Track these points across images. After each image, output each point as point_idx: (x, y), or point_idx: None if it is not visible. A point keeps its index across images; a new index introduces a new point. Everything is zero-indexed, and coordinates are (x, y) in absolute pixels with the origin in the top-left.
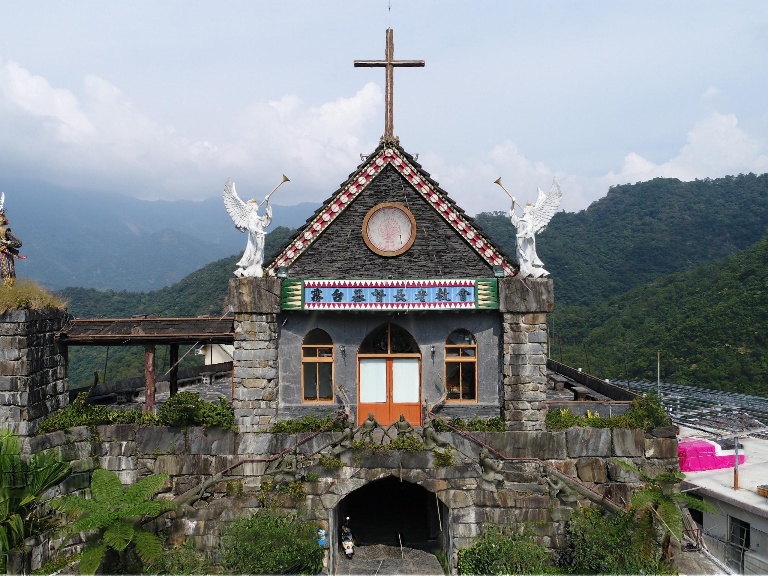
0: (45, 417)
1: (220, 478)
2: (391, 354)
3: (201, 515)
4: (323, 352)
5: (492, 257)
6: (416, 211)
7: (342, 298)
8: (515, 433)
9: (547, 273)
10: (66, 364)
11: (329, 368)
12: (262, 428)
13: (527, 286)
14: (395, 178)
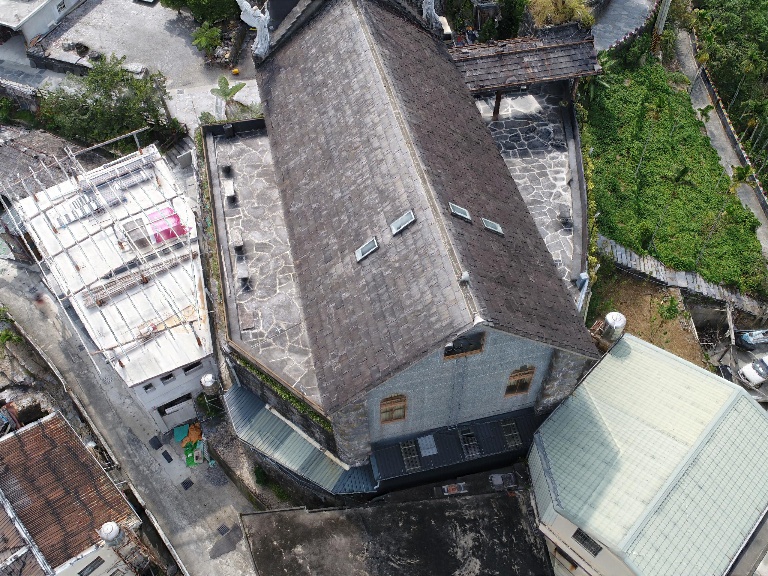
0: None
1: None
2: None
3: None
4: None
5: None
6: None
7: None
8: None
9: None
10: None
11: None
12: None
13: None
14: None
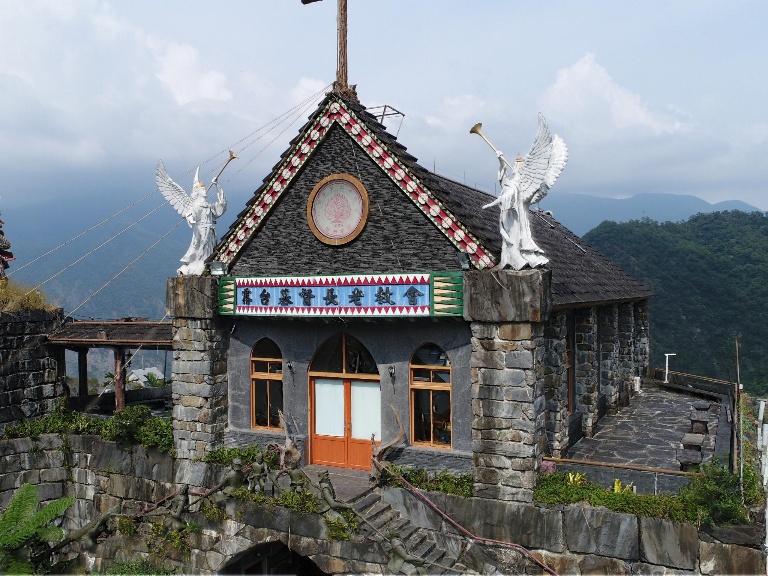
0: (19, 422)
1: (114, 512)
2: (346, 374)
3: (99, 551)
4: (275, 367)
5: (463, 241)
6: (369, 182)
7: (269, 300)
8: (486, 501)
9: (540, 262)
10: (62, 367)
11: (279, 388)
12: (197, 455)
13: (500, 282)
14: (344, 141)
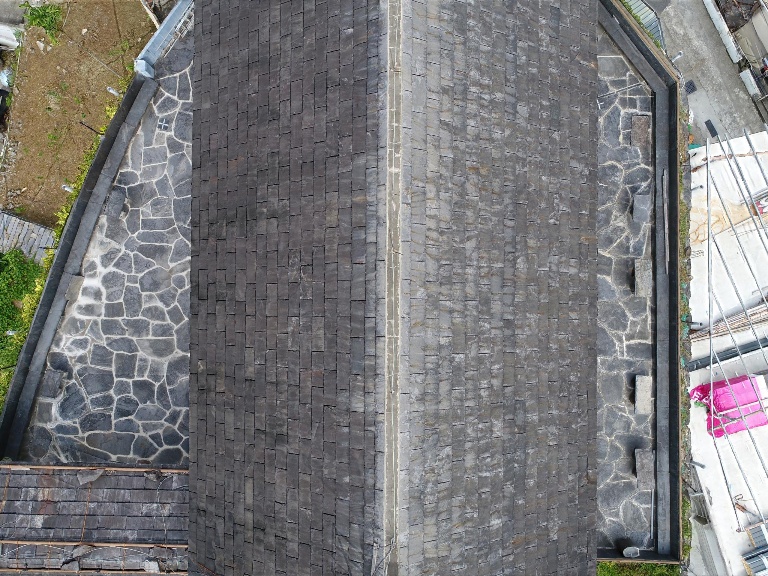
0: None
1: None
2: None
3: None
4: None
5: None
6: None
7: None
8: None
9: None
10: None
11: None
12: None
13: None
14: None
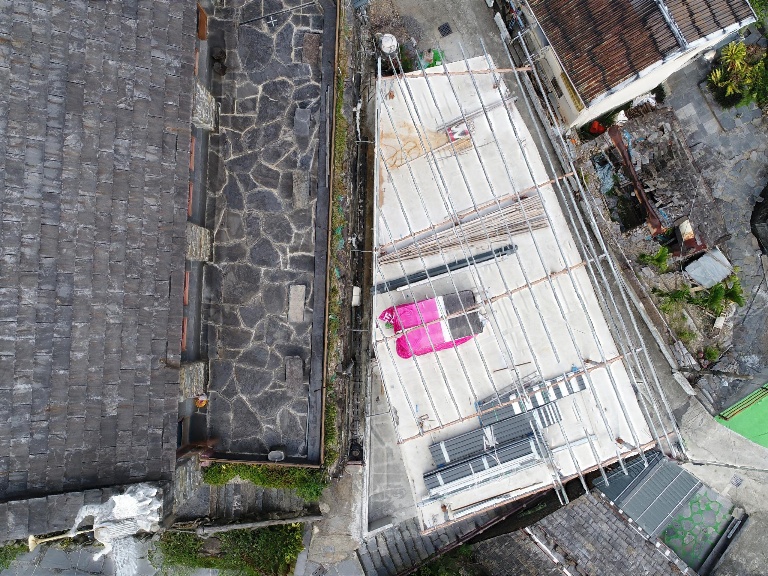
0: None
1: None
2: None
3: None
4: None
5: None
6: None
7: None
8: None
9: None
10: None
11: None
12: None
13: None
14: None
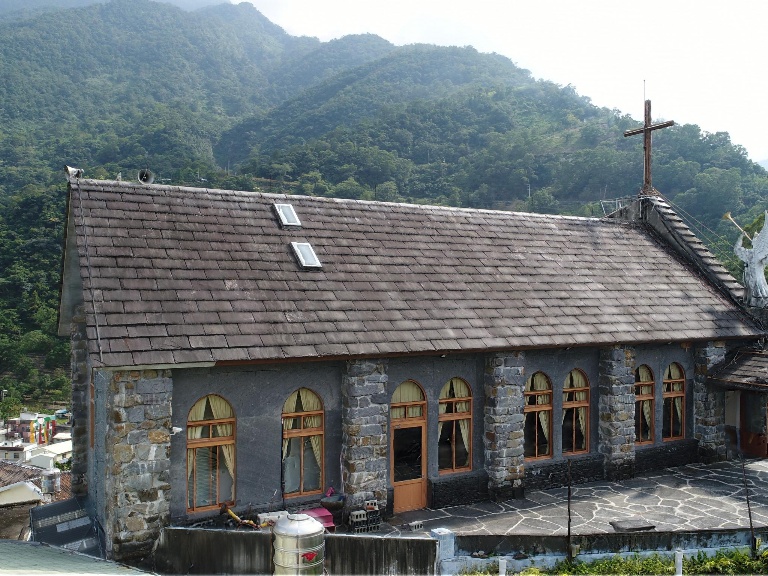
0: None
1: None
2: None
3: None
4: None
5: None
6: None
7: None
8: None
9: None
10: None
11: None
12: None
13: None
14: None
